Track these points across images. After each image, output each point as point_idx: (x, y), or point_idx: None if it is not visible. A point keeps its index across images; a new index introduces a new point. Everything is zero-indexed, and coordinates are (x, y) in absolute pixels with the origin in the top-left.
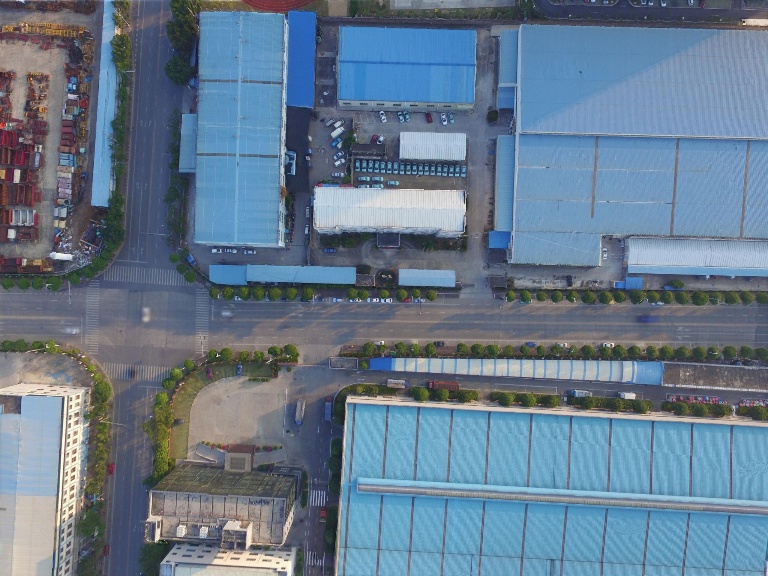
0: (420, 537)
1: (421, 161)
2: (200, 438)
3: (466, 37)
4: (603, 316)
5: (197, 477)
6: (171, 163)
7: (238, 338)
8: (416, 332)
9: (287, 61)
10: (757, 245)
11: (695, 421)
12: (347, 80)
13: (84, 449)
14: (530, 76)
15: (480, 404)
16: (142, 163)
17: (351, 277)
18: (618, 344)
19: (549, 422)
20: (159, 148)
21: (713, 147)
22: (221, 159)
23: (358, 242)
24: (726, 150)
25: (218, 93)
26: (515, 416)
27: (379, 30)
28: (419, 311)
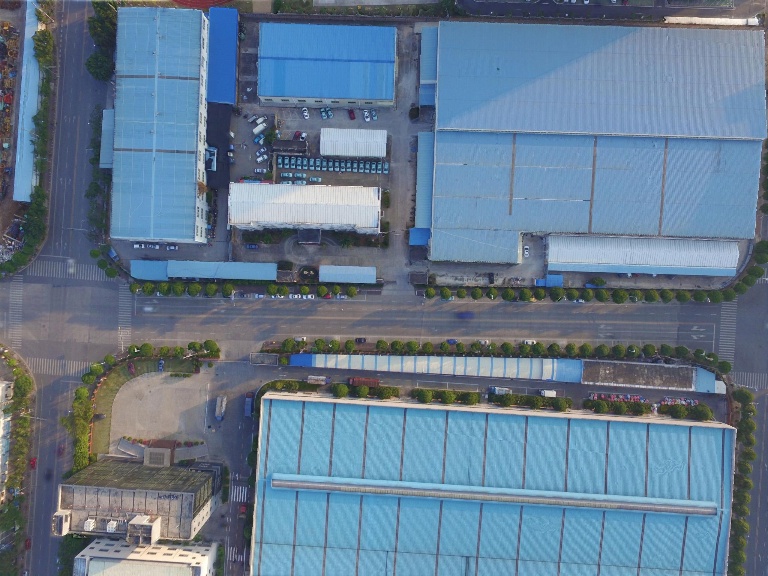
0: (335, 533)
1: (343, 158)
2: (122, 433)
3: (386, 34)
4: (525, 313)
5: (112, 472)
6: (92, 158)
7: (161, 333)
8: (338, 328)
9: (207, 57)
10: (677, 243)
11: (611, 419)
12: (267, 76)
13: (5, 443)
14: (448, 73)
15: (399, 401)
16: (66, 158)
17: (272, 273)
18: (540, 342)
19: (465, 419)
20: (83, 144)
21: (631, 145)
22: (138, 154)
23: (280, 238)
24: (644, 148)
25: (135, 89)
26: (431, 413)
27: (299, 26)
28: (341, 307)
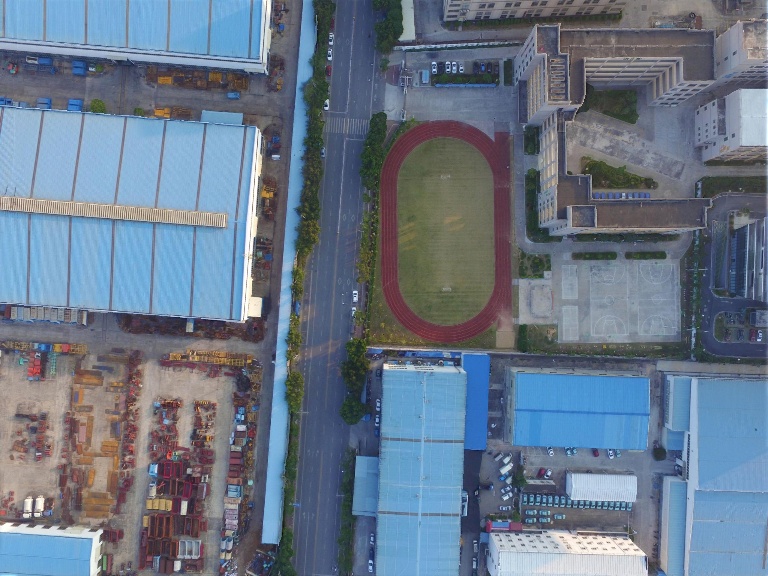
0: None
1: None
2: None
3: (640, 385)
4: None
5: None
6: (344, 504)
7: None
8: None
9: None
10: None
11: None
12: (522, 427)
13: None
14: (707, 433)
15: None
16: (309, 493)
17: None
18: None
19: None
20: (326, 478)
21: None
22: (403, 518)
23: None
24: None
25: (401, 452)
26: None
27: (554, 377)
28: None
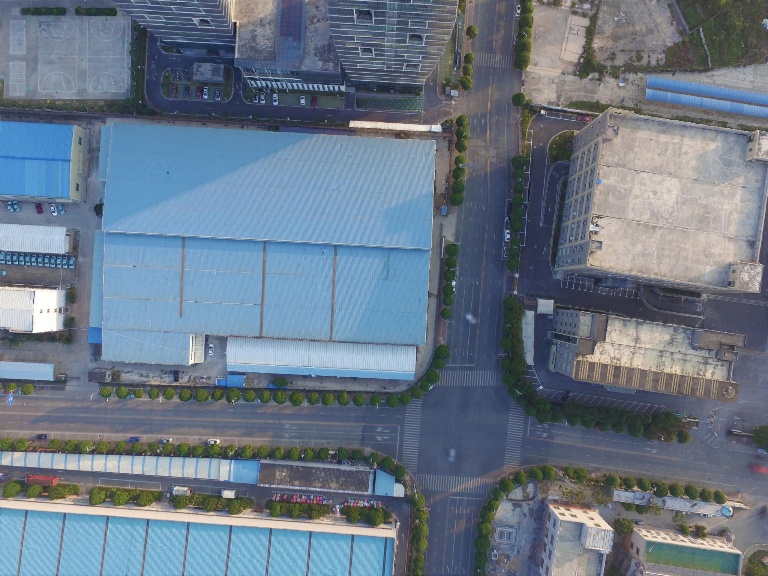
0: None
1: (28, 252)
2: None
3: (64, 132)
4: (210, 412)
5: None
6: None
7: None
8: (20, 424)
9: None
10: (356, 346)
11: (272, 526)
12: None
13: None
14: (117, 175)
15: (69, 501)
16: None
17: None
18: (224, 440)
19: (125, 524)
20: None
21: (300, 251)
22: None
23: None
24: (313, 254)
25: None
26: (91, 517)
27: None
28: (24, 403)
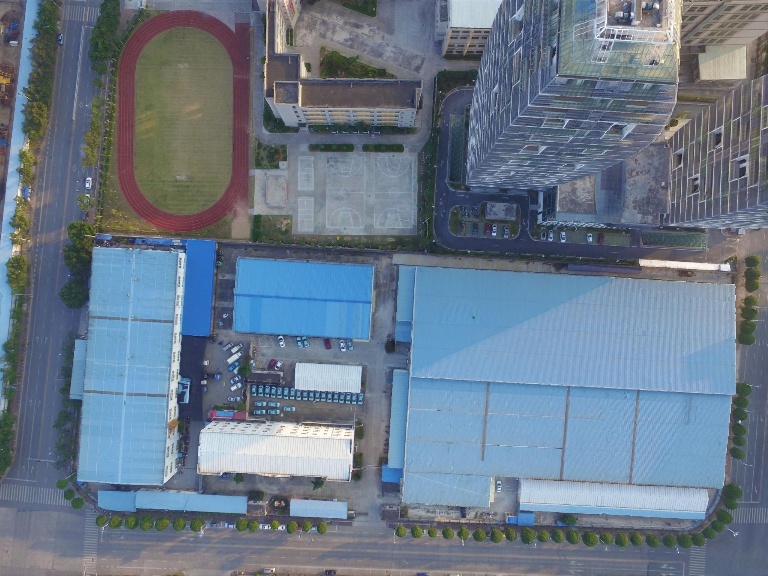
0: None
1: None
2: None
3: (363, 273)
4: (496, 548)
5: None
6: (62, 388)
7: (127, 561)
8: (308, 559)
9: (183, 291)
10: (648, 486)
11: None
12: (242, 313)
13: None
14: (423, 320)
15: None
16: (36, 380)
17: (242, 507)
18: None
19: None
20: (54, 365)
21: (603, 395)
22: (108, 397)
23: None
24: (616, 398)
25: (108, 330)
26: None
27: (277, 263)
28: (312, 538)
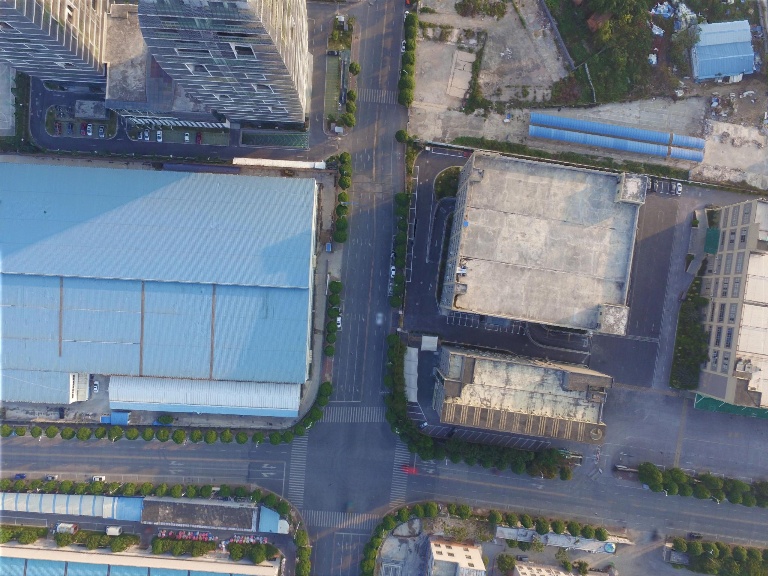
0: None
1: None
2: None
3: None
4: (96, 449)
5: None
6: None
7: None
8: None
9: None
10: (239, 384)
11: (149, 565)
12: None
13: None
14: None
15: None
16: None
17: None
18: (110, 477)
19: (4, 563)
20: None
21: (178, 290)
22: None
23: None
24: (192, 293)
25: None
26: None
27: None
28: None
